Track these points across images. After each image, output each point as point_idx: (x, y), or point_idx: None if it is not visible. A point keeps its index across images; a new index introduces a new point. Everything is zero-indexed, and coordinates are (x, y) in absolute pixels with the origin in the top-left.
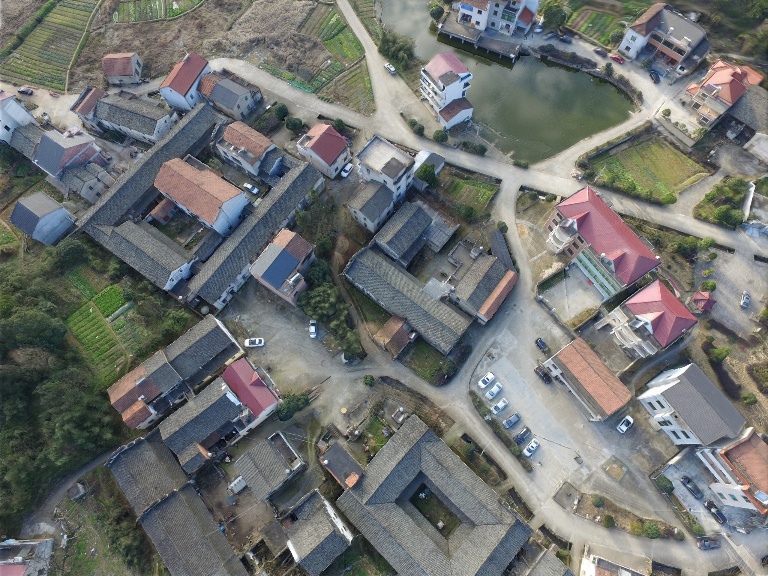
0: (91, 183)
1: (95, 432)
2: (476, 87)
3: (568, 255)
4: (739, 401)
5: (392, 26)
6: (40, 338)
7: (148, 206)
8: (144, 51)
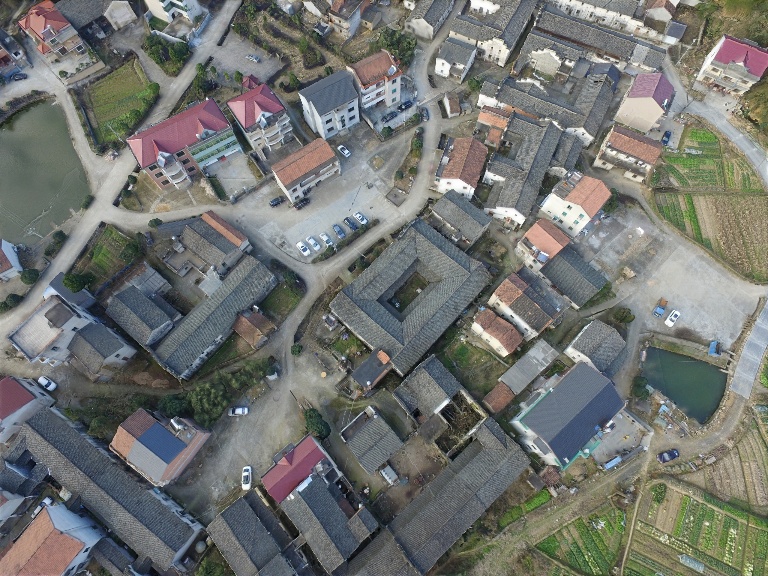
0: None
1: None
2: None
3: (195, 173)
4: None
5: None
6: None
7: None
8: None
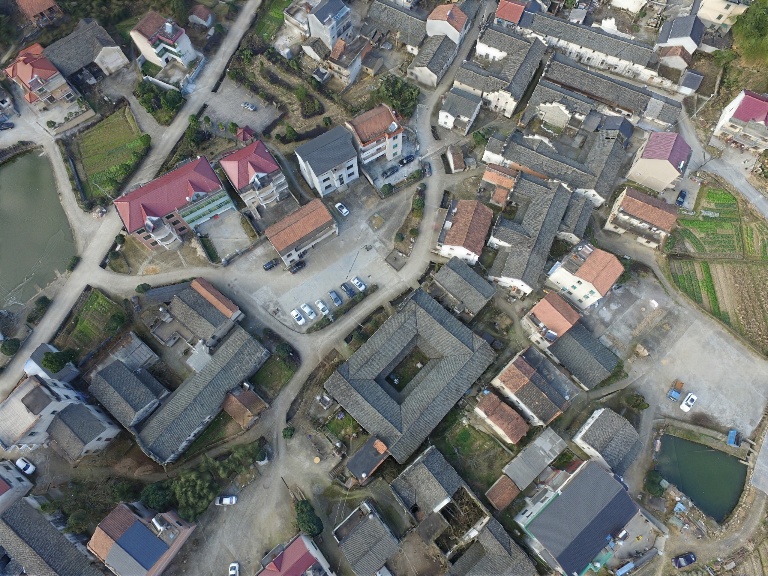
0: None
1: None
2: None
3: (185, 232)
4: (329, 129)
5: None
6: None
7: None
8: None
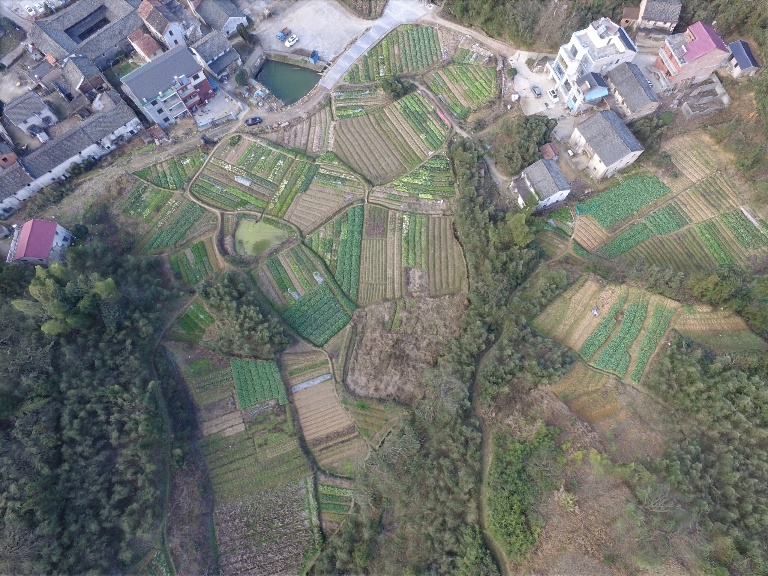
0: None
1: None
2: None
3: None
4: None
5: None
6: None
7: None
8: None
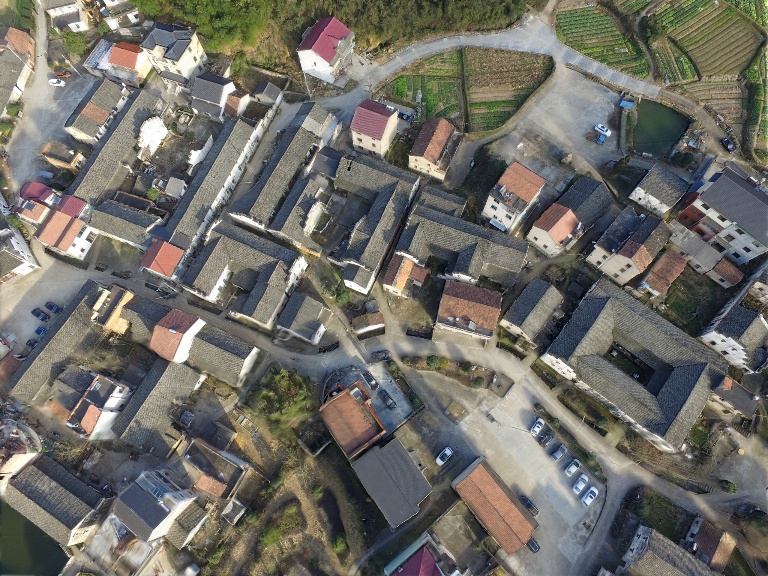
0: None
1: None
2: None
3: None
4: (323, 489)
5: None
6: None
7: None
8: None
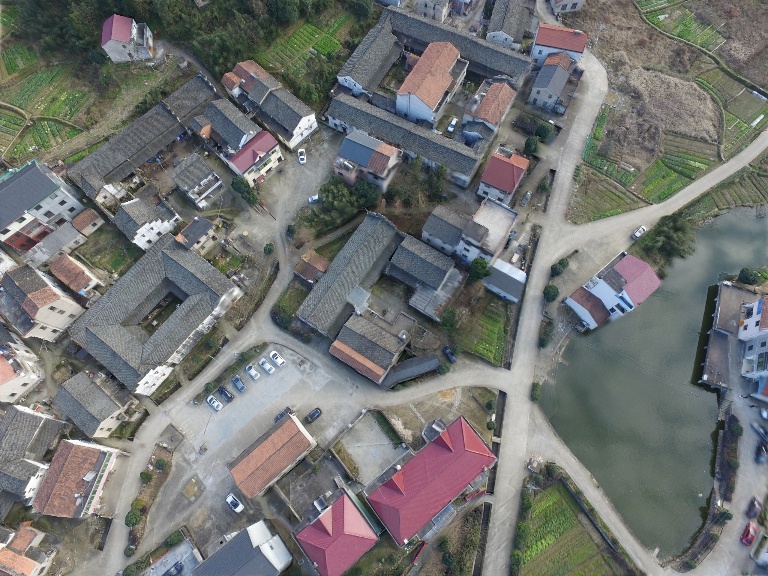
0: (429, 3)
1: (220, 60)
2: (622, 321)
3: None
4: None
5: (710, 229)
6: (276, 1)
7: (420, 51)
8: (595, 7)
